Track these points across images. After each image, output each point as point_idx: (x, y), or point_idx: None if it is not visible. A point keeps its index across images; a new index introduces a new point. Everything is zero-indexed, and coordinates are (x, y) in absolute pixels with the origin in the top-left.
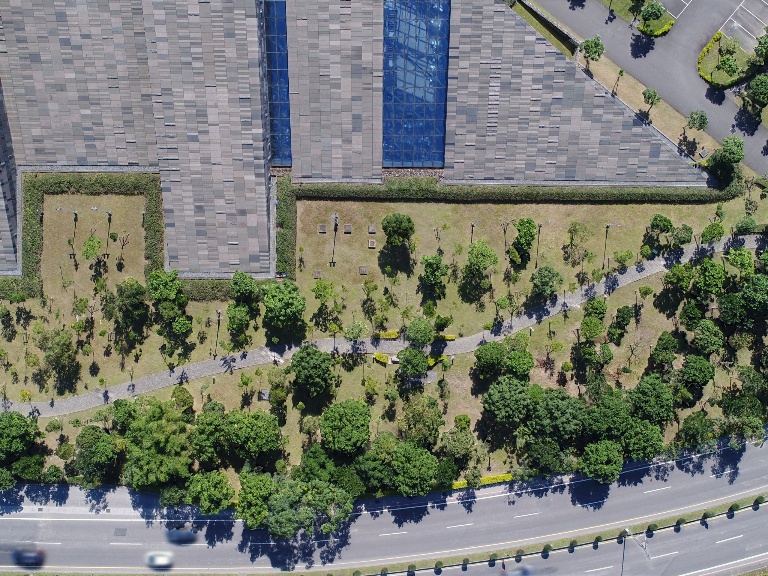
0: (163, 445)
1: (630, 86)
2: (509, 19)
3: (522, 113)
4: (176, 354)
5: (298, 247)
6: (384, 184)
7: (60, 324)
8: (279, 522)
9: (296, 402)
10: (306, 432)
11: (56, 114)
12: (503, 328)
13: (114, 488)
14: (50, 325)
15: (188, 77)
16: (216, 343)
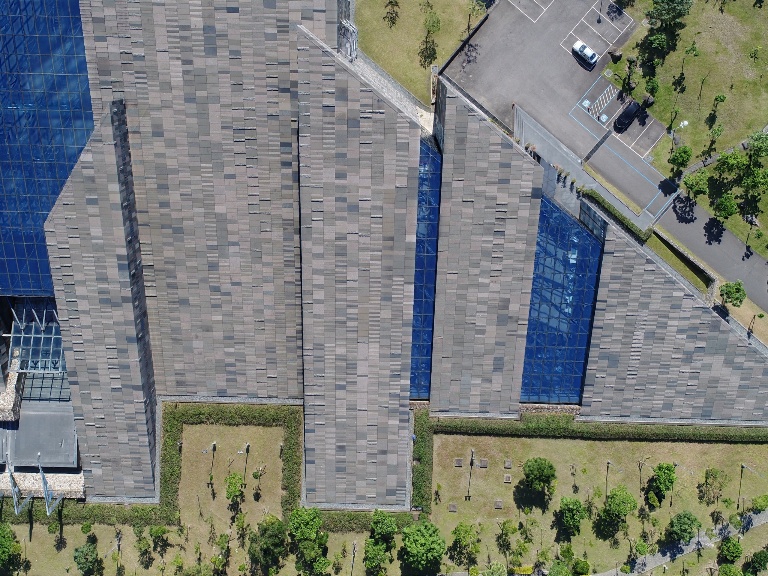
0: None
1: (766, 324)
2: (659, 277)
3: (664, 359)
4: None
5: (434, 480)
6: (522, 421)
7: None
8: None
9: None
10: None
11: (200, 351)
12: (637, 565)
13: None
14: (187, 553)
15: (341, 334)
16: (351, 574)
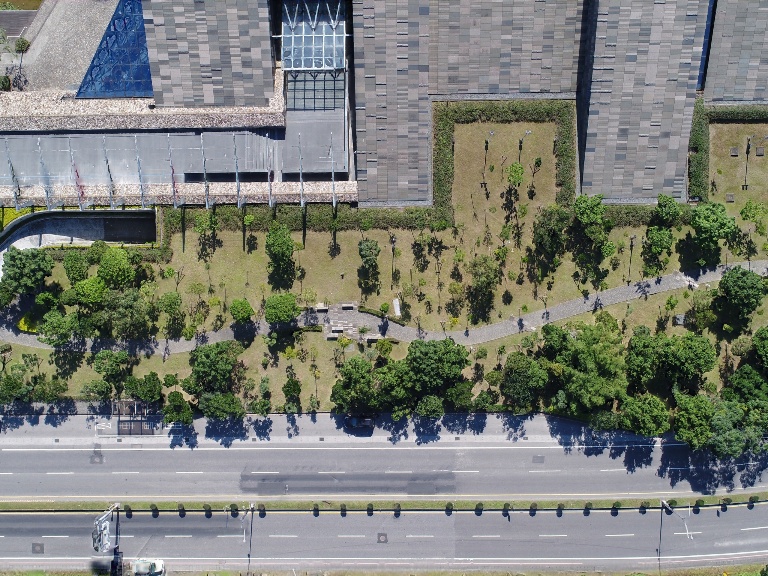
0: (608, 367)
1: None
2: None
3: None
4: (589, 281)
5: (710, 171)
6: None
7: (472, 253)
8: (729, 441)
9: (712, 326)
10: (737, 354)
11: (476, 40)
12: None
13: (532, 416)
14: None
15: None
16: (629, 269)
